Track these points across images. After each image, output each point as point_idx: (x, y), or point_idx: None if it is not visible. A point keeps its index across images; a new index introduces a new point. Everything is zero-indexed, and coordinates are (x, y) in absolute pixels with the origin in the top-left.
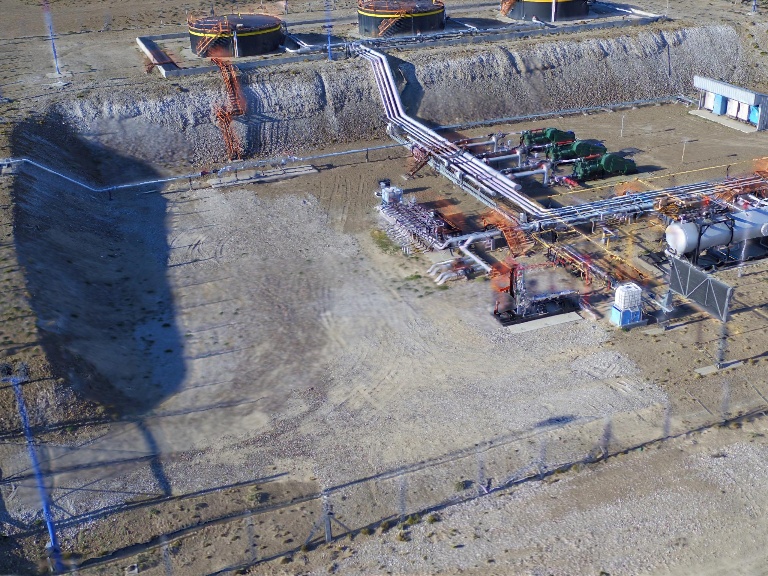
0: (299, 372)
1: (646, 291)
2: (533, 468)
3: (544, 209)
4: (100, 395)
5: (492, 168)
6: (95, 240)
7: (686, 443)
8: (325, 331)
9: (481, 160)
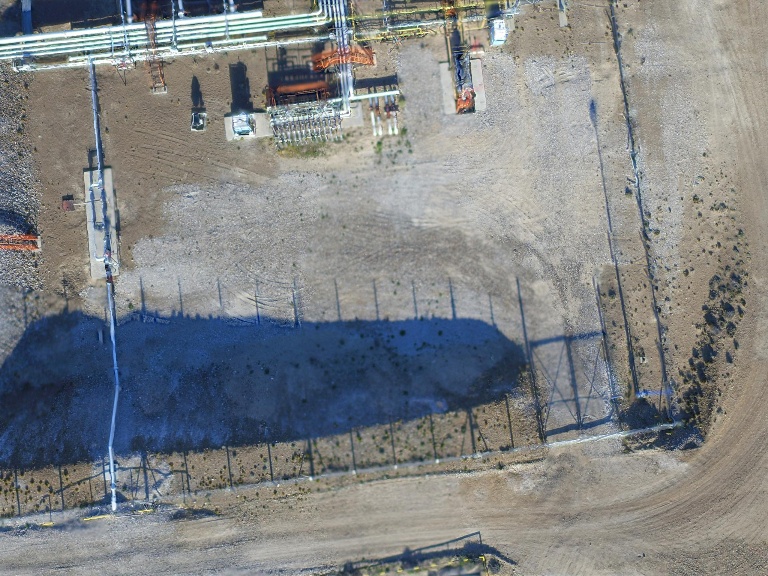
0: (492, 254)
1: (456, 1)
2: (626, 155)
3: (318, 13)
4: (509, 374)
5: (210, 17)
6: (237, 385)
7: (628, 71)
8: (442, 228)
9: (182, 18)
